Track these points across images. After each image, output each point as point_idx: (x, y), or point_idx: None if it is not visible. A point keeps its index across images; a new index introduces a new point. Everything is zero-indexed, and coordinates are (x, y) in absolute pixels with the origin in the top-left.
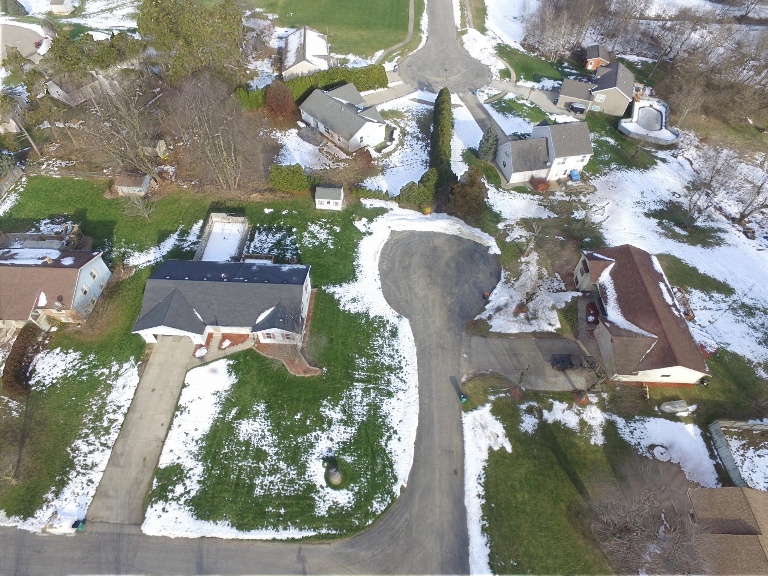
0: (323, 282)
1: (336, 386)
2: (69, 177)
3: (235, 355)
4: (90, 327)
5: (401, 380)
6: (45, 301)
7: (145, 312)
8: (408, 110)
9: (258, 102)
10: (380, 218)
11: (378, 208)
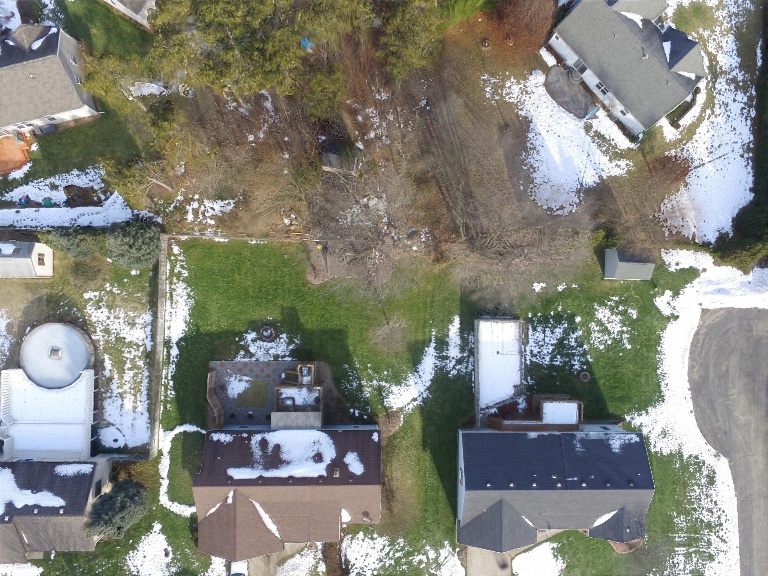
0: (625, 408)
1: (659, 555)
2: (240, 240)
3: (558, 538)
4: (388, 510)
5: (722, 540)
6: (349, 517)
7: (467, 521)
8: (722, 0)
9: (474, 7)
10: (689, 288)
11: (687, 270)
